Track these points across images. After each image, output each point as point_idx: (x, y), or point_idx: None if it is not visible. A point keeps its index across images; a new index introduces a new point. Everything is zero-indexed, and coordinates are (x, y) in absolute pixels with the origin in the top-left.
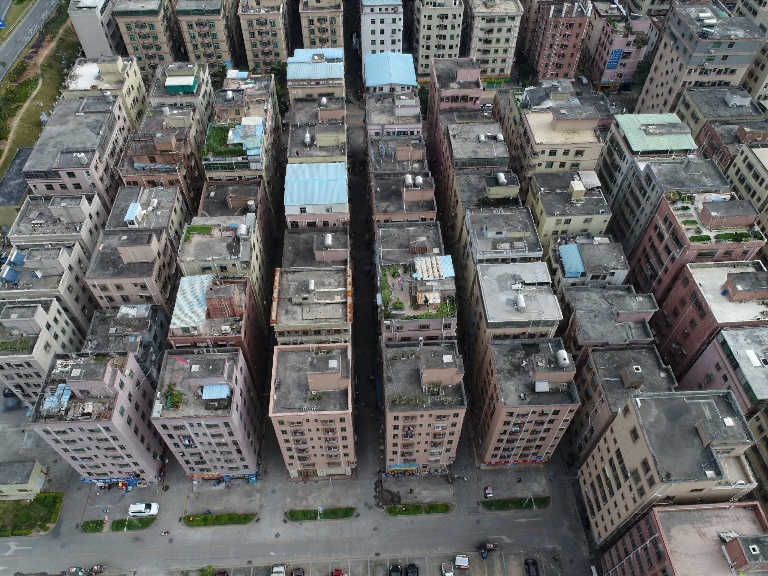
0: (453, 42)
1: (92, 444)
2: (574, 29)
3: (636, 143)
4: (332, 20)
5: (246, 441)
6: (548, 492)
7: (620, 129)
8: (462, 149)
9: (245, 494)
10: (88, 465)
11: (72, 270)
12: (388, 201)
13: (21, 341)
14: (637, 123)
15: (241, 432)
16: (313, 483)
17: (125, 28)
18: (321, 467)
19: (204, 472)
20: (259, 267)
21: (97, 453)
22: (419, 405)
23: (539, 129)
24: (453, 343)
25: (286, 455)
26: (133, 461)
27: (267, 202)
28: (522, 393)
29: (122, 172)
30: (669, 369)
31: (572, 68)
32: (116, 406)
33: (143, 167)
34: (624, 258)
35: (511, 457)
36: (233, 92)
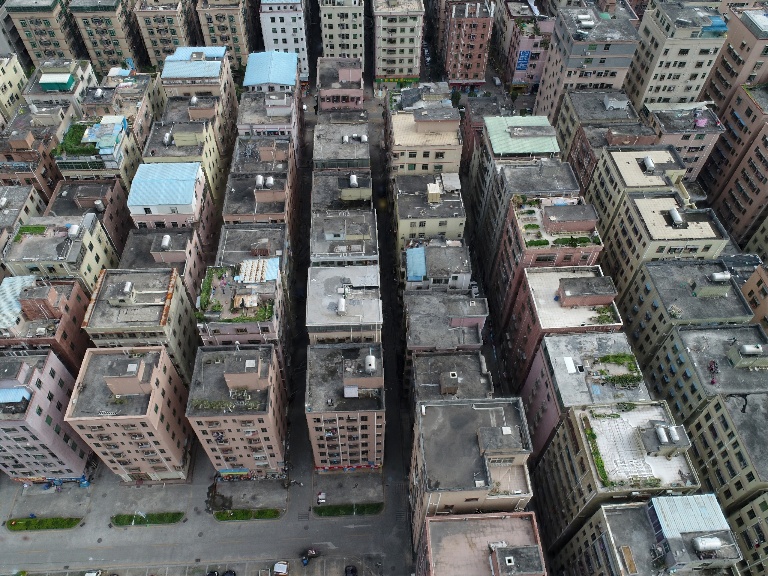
0: (357, 41)
1: None
2: (478, 30)
3: (498, 146)
4: (230, 18)
5: (61, 445)
6: (383, 498)
7: (487, 131)
8: (323, 150)
9: (75, 498)
10: None
11: None
12: (241, 202)
13: None
14: (504, 125)
15: (48, 436)
16: (146, 487)
17: (20, 24)
18: (149, 471)
19: (28, 476)
20: (103, 268)
21: None
22: (222, 410)
23: (402, 130)
24: (270, 347)
25: (105, 459)
26: None
27: None
28: (331, 399)
29: None
30: (489, 375)
31: (481, 69)
32: None
33: None
34: (468, 262)
35: (342, 462)
36: (105, 90)
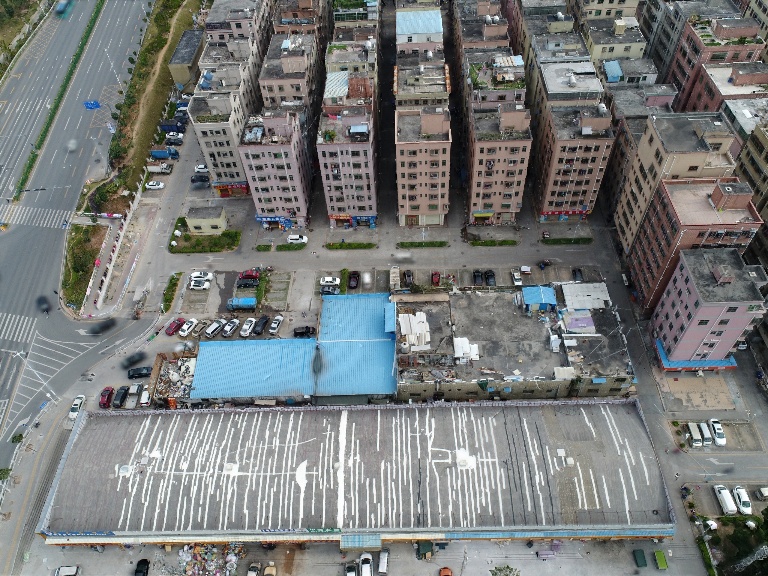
0: None
1: (272, 173)
2: None
3: None
4: None
5: None
6: (591, 236)
7: None
8: (529, 2)
9: (367, 234)
10: (265, 198)
11: (245, 83)
12: (472, 37)
13: (220, 115)
14: None
15: (372, 167)
16: (416, 229)
17: None
18: (423, 211)
19: (341, 212)
20: None
21: (273, 184)
22: None
23: None
24: None
25: (400, 194)
26: (295, 196)
27: (378, 49)
28: None
29: (275, 23)
30: None
31: None
32: (292, 139)
33: (288, 22)
34: (654, 67)
35: (563, 205)
36: None
